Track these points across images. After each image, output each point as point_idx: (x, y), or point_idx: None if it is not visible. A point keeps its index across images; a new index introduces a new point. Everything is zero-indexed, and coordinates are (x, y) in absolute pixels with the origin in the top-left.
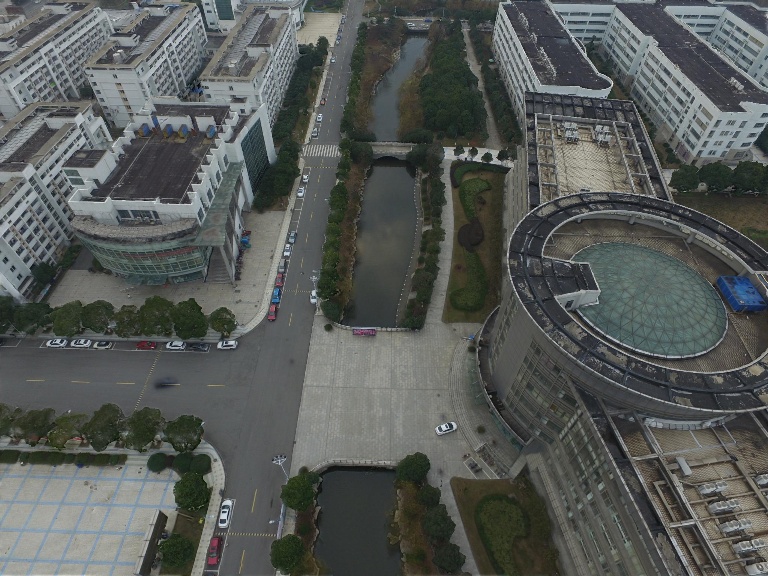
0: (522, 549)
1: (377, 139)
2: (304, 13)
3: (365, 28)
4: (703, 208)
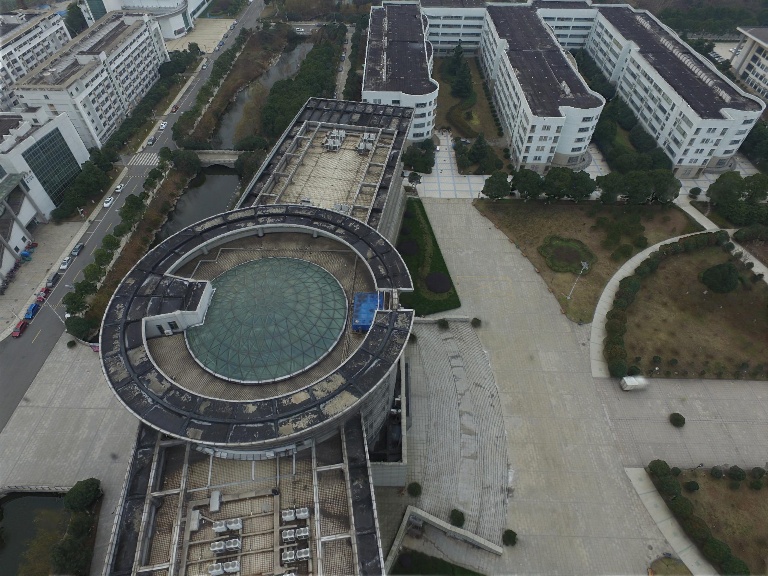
0: None
1: (226, 146)
2: (197, 19)
3: (246, 34)
4: (516, 215)
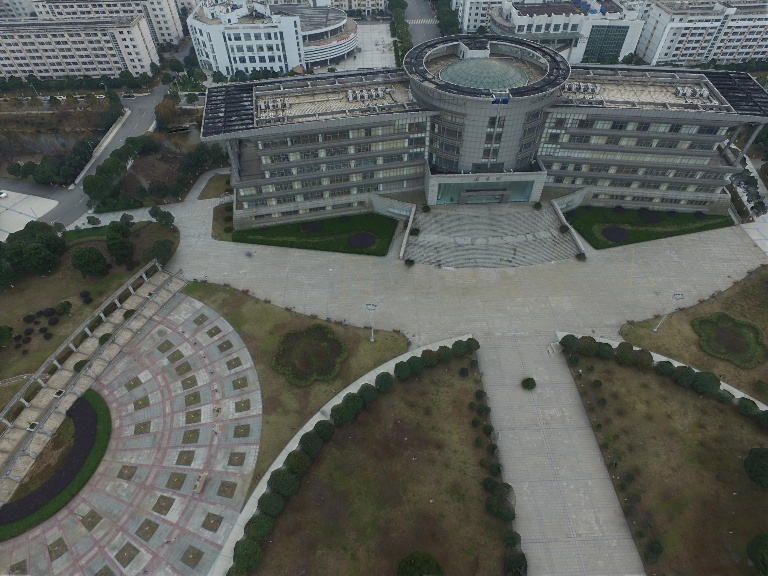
0: None
1: None
2: None
3: None
4: None
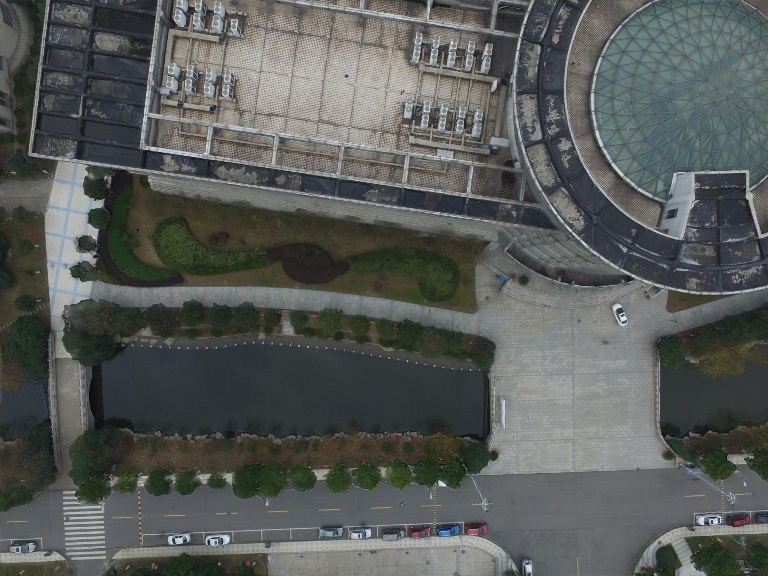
0: None
1: None
2: None
3: None
4: None
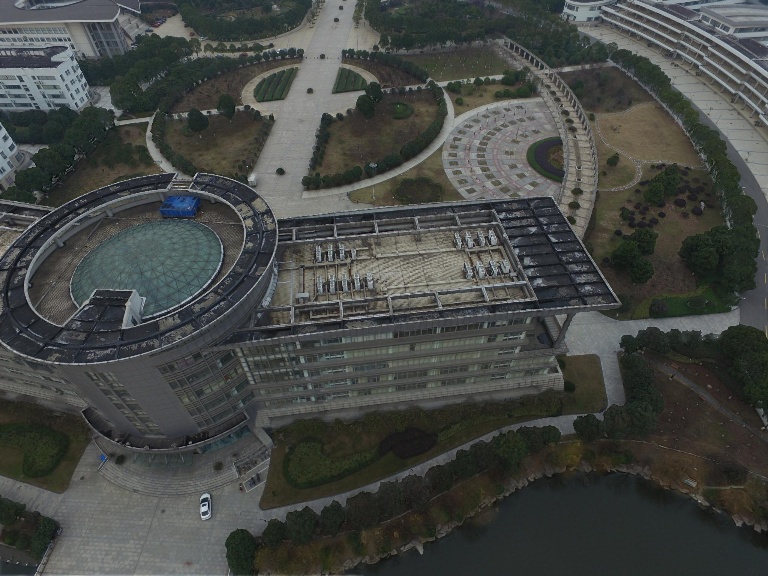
0: (331, 450)
1: None
2: None
3: None
4: None
